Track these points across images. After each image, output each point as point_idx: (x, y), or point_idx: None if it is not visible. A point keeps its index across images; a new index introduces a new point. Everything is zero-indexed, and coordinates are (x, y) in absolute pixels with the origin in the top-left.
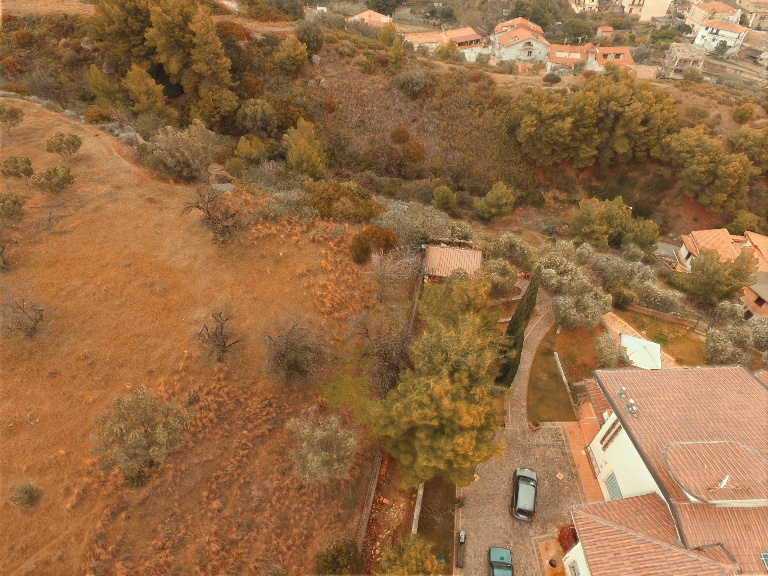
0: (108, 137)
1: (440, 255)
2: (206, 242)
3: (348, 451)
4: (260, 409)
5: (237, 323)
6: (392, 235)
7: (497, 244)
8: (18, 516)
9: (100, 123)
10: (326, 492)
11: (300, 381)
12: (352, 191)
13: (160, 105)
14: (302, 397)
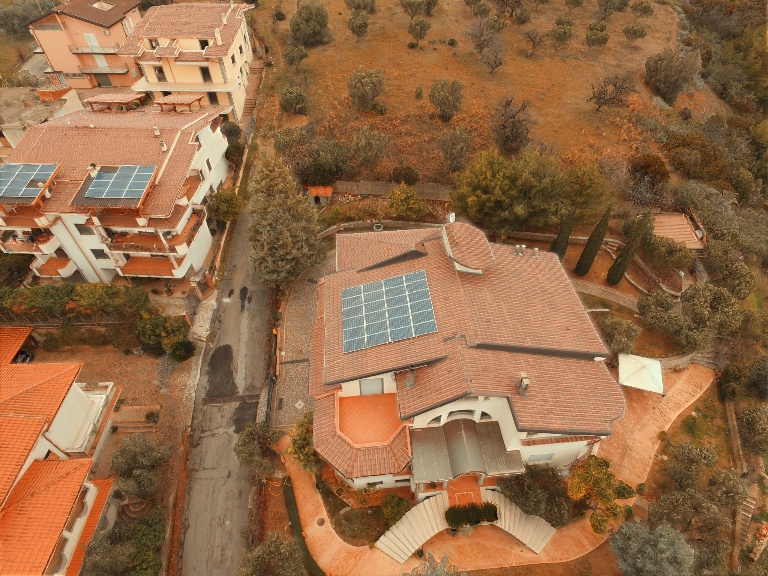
0: None
1: (676, 222)
2: (593, 105)
3: (455, 150)
4: (479, 142)
5: (532, 127)
6: (660, 171)
7: (725, 260)
8: (412, 97)
9: (688, 46)
10: None
11: (502, 154)
12: (738, 177)
13: (758, 68)
14: None
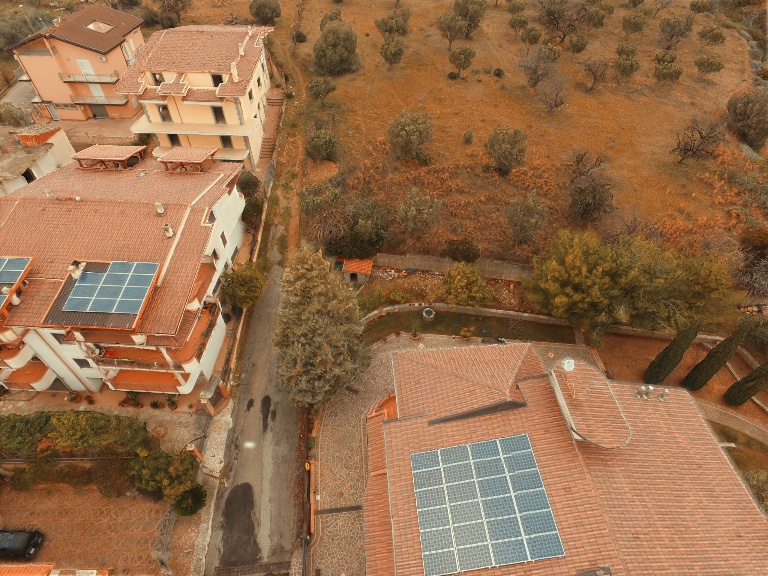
0: (749, 85)
1: None
2: (673, 155)
3: (528, 223)
4: None
5: None
6: None
7: None
8: (459, 142)
9: (765, 79)
10: (505, 244)
11: (576, 221)
12: None
13: None
14: (565, 225)
